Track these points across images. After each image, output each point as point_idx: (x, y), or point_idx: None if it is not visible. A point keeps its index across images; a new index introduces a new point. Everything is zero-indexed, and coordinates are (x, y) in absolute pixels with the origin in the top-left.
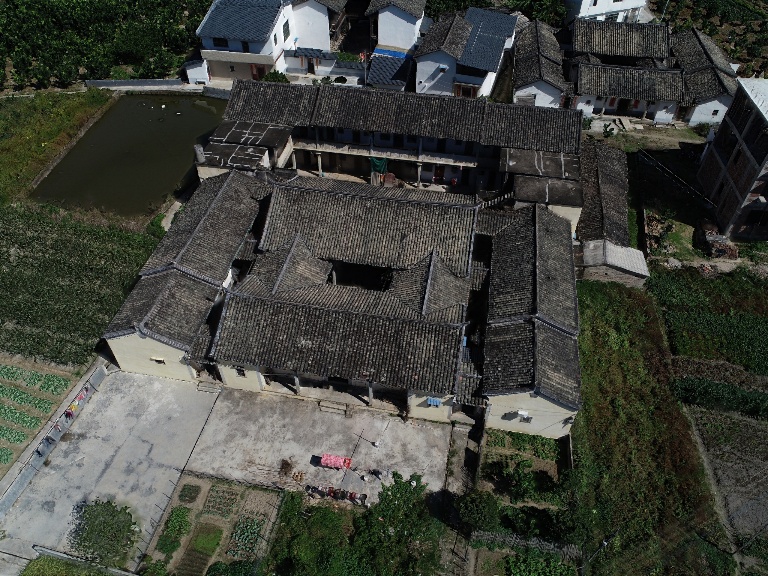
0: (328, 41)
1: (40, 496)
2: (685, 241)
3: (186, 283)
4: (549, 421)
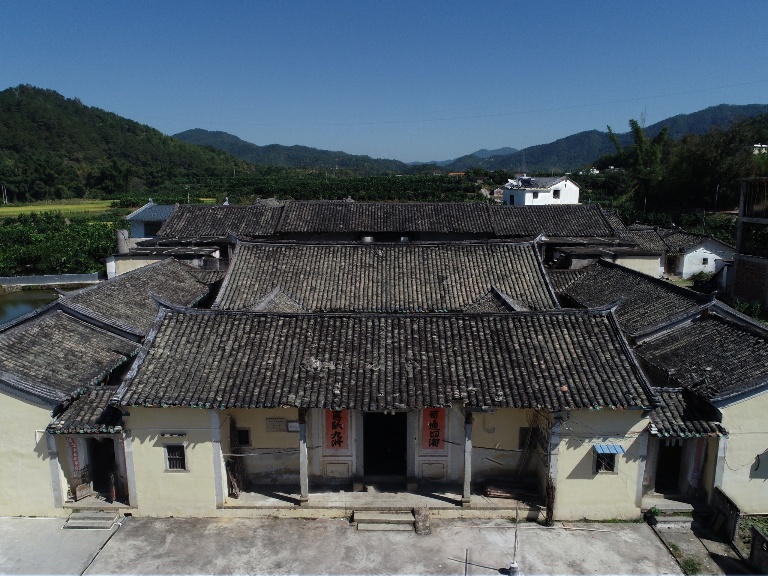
0: None
1: None
2: None
3: (77, 329)
4: None
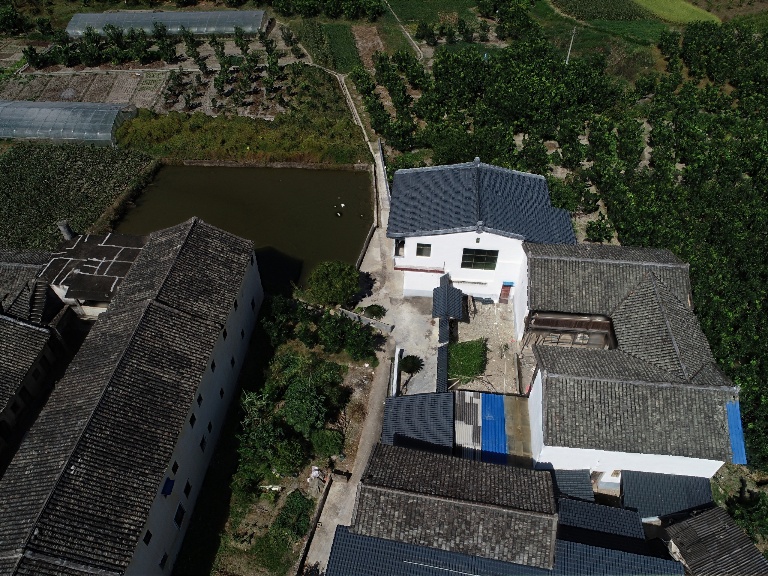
0: (521, 325)
1: None
2: None
3: None
4: None
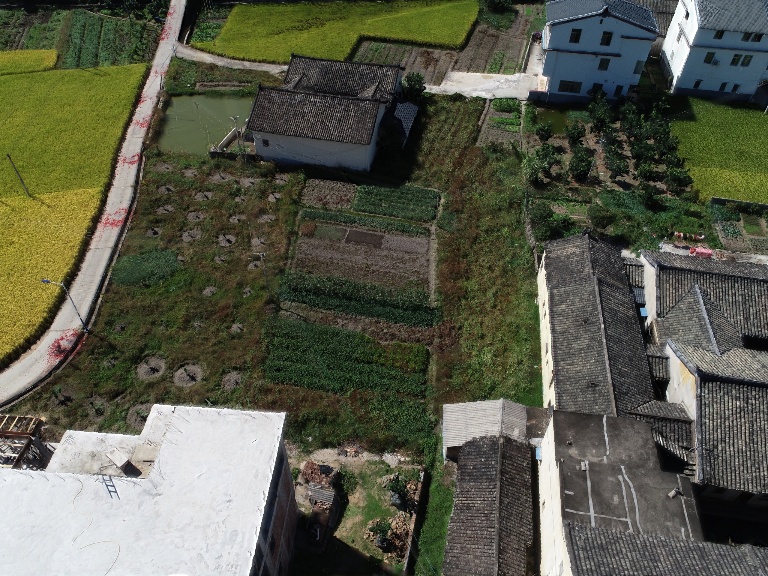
0: None
1: None
2: (358, 509)
3: None
4: None
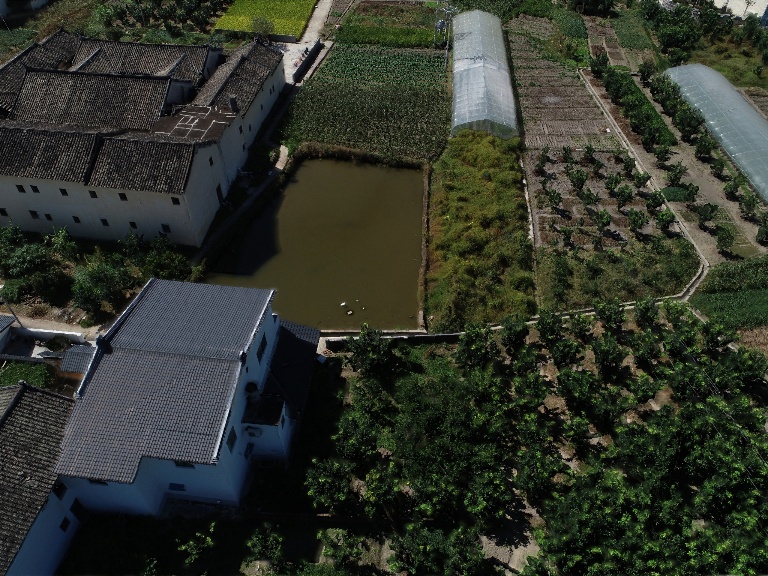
0: None
1: None
2: None
3: None
4: None
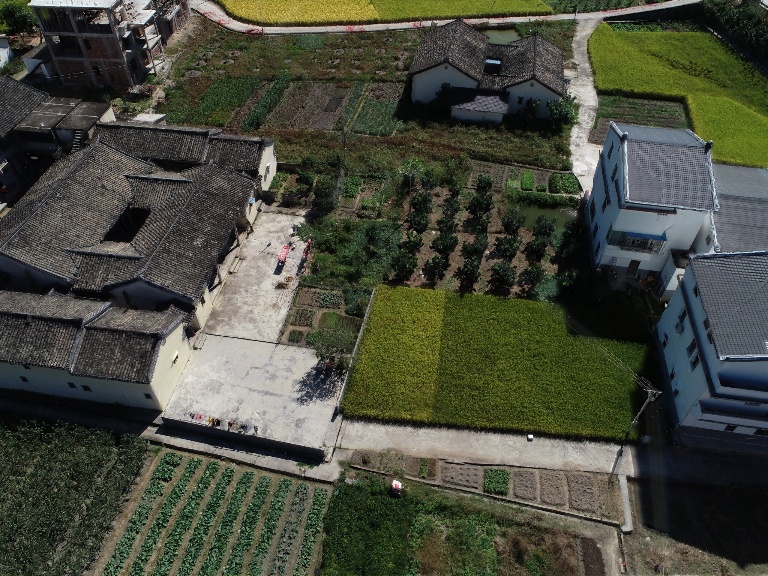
0: None
1: (290, 432)
2: None
3: None
4: (271, 162)
